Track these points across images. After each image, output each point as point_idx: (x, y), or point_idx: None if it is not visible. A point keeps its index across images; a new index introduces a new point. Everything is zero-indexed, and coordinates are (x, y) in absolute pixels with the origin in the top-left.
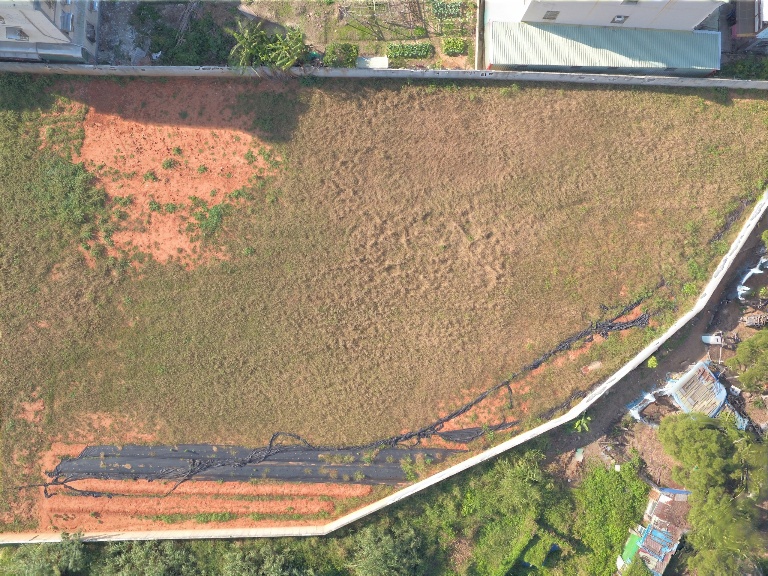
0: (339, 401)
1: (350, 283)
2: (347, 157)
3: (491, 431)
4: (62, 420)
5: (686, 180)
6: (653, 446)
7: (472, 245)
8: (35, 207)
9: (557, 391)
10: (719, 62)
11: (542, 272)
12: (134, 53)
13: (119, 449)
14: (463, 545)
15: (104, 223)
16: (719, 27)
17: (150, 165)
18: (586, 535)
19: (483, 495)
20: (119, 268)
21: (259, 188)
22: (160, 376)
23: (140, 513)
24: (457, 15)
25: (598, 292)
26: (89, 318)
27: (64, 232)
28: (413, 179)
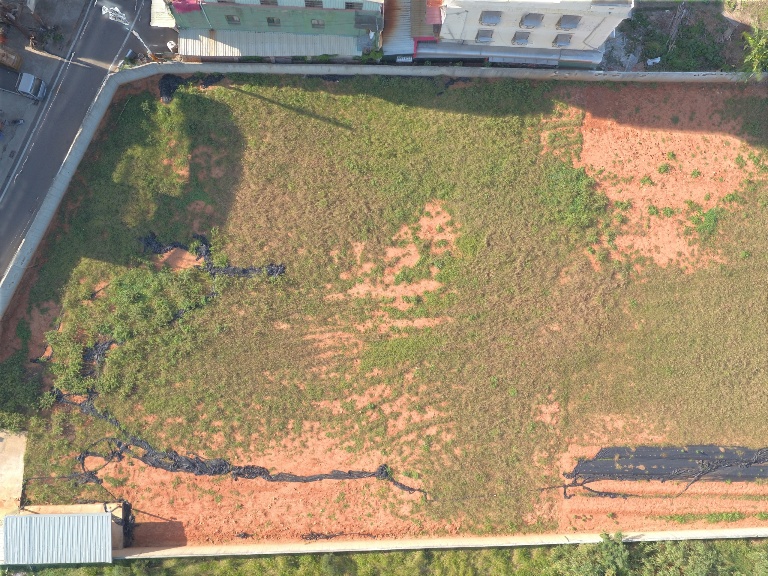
0: None
1: None
2: None
3: None
4: (577, 422)
5: None
6: None
7: None
8: (543, 212)
9: None
10: None
11: None
12: (629, 59)
13: (633, 450)
14: None
15: (606, 227)
16: None
17: (646, 170)
18: None
19: None
20: (624, 272)
21: (751, 192)
22: (668, 378)
23: (654, 513)
24: None
25: None
26: (599, 321)
27: (570, 236)
28: None
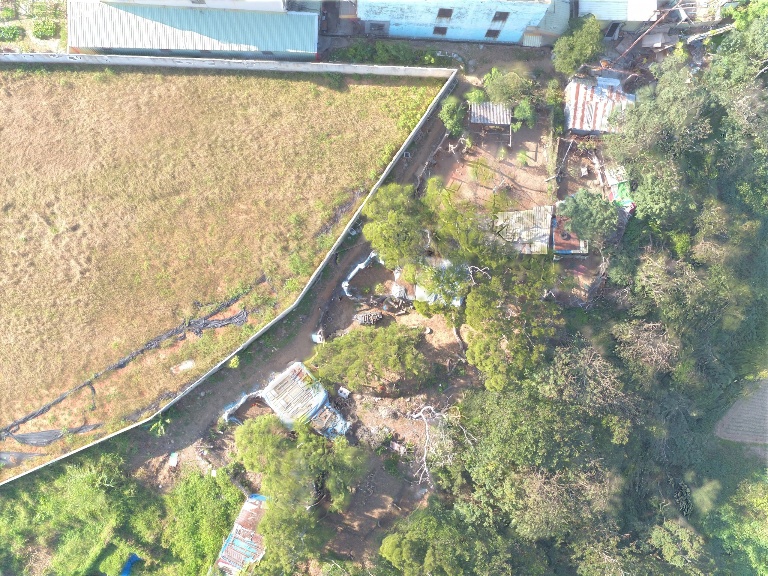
0: None
1: None
2: None
3: (70, 434)
4: None
5: (292, 170)
6: (254, 450)
7: (57, 238)
8: None
9: (145, 392)
10: (316, 45)
11: (131, 266)
12: None
13: None
14: (40, 554)
15: None
16: None
17: None
18: (176, 544)
19: (58, 501)
20: None
21: None
22: None
23: None
24: None
25: (191, 288)
26: None
27: None
28: None
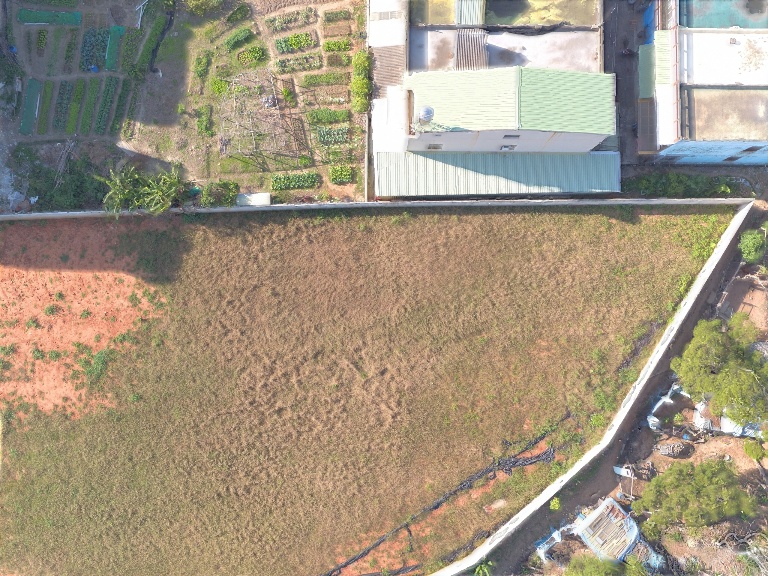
0: (231, 551)
1: (240, 427)
2: (234, 296)
3: (390, 575)
4: None
5: (591, 305)
6: None
7: (366, 382)
8: None
9: (459, 531)
10: (619, 184)
11: (440, 408)
12: (12, 198)
13: None
14: None
15: None
16: (625, 138)
17: (32, 312)
18: None
19: None
20: (3, 421)
21: (144, 332)
22: (48, 530)
23: None
24: (345, 141)
25: (499, 427)
26: None
27: None
28: (303, 316)
